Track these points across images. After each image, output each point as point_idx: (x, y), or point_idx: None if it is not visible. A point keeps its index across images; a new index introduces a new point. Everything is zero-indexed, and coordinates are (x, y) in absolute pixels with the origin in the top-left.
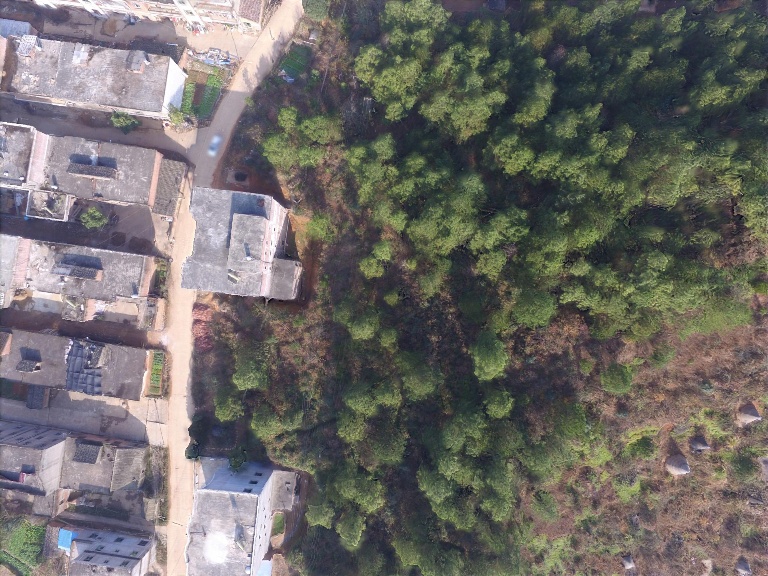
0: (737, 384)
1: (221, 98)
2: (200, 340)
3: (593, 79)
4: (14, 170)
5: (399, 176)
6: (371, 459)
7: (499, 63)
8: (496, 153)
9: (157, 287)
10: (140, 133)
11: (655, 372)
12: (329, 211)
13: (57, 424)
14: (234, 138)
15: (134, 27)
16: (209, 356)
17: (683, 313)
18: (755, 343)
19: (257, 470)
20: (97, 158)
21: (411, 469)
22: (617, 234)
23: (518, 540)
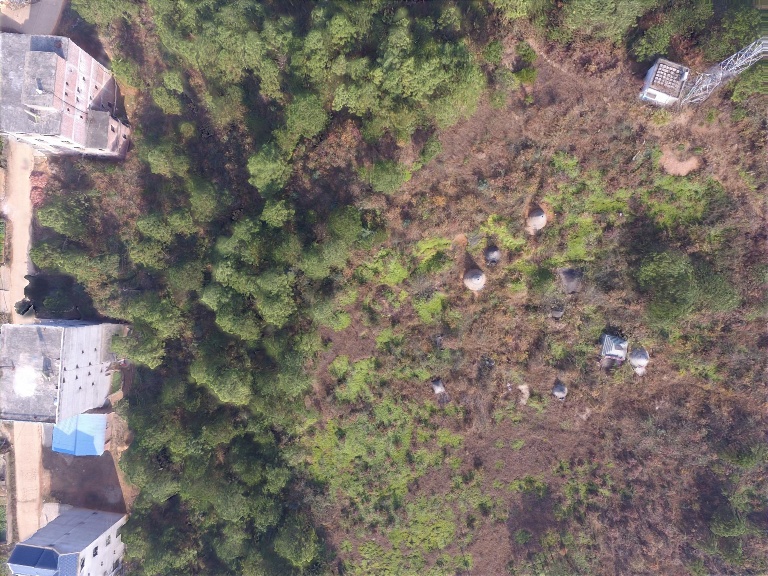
0: (509, 178)
1: None
2: (37, 206)
3: None
4: None
5: (186, 8)
6: (180, 295)
7: None
8: None
9: None
10: None
11: (435, 177)
12: (147, 67)
13: None
14: (64, 10)
15: None
16: None
17: (431, 94)
18: (525, 135)
19: (86, 323)
20: None
21: None
22: (374, 29)
23: (298, 346)
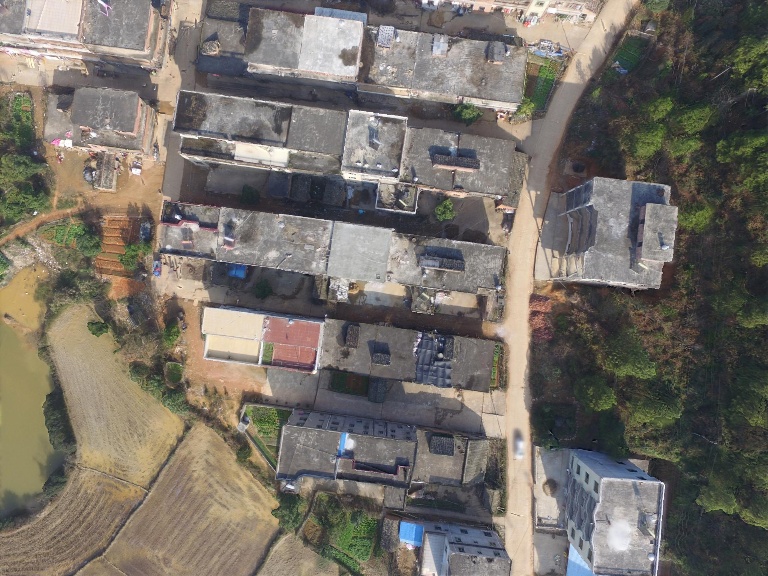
0: None
1: (555, 89)
2: (540, 331)
3: None
4: (387, 162)
5: None
6: (753, 445)
7: None
8: None
9: None
10: (473, 125)
11: None
12: (683, 201)
13: (391, 417)
14: (570, 129)
15: (462, 18)
16: (562, 347)
17: None
18: None
19: (615, 459)
20: (456, 150)
21: None
22: None
23: None
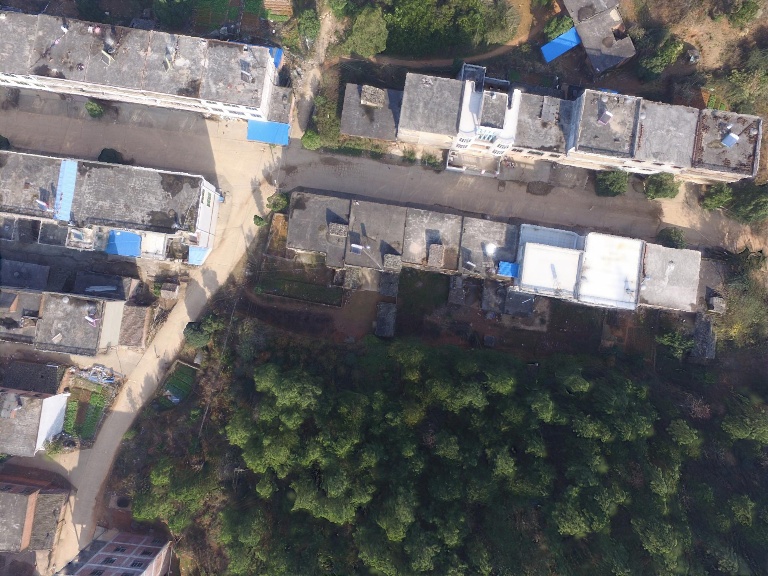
0: None
1: (104, 418)
2: None
3: (461, 473)
4: None
5: (265, 565)
6: None
7: (366, 455)
8: None
9: None
10: None
11: None
12: (209, 554)
13: None
14: (117, 462)
15: None
16: None
17: None
18: None
19: None
20: None
21: None
22: None
23: None
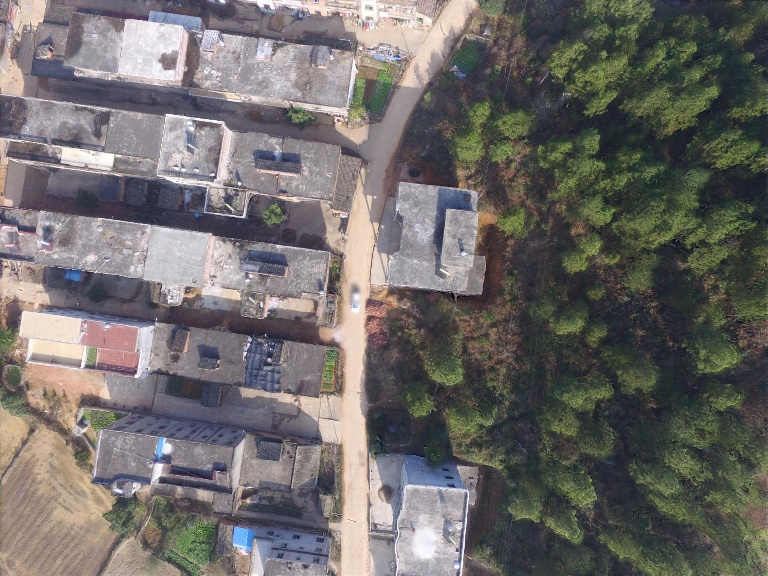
0: None
1: (392, 94)
2: (375, 336)
3: None
4: (204, 166)
5: (607, 171)
6: (569, 453)
7: (709, 58)
8: (710, 148)
9: (333, 283)
10: (310, 129)
11: None
12: (512, 206)
13: (228, 422)
14: (407, 134)
15: (302, 22)
16: (391, 352)
17: None
18: None
19: (442, 465)
20: (281, 154)
21: (618, 462)
22: None
23: (742, 531)
